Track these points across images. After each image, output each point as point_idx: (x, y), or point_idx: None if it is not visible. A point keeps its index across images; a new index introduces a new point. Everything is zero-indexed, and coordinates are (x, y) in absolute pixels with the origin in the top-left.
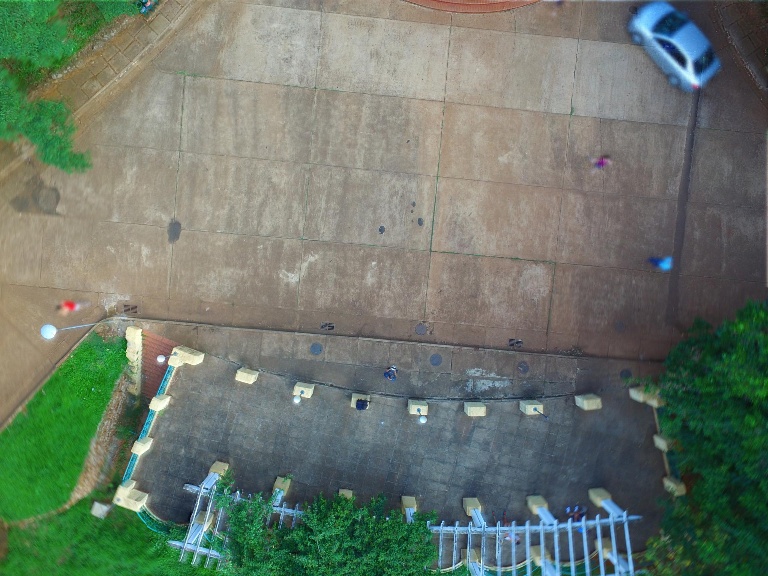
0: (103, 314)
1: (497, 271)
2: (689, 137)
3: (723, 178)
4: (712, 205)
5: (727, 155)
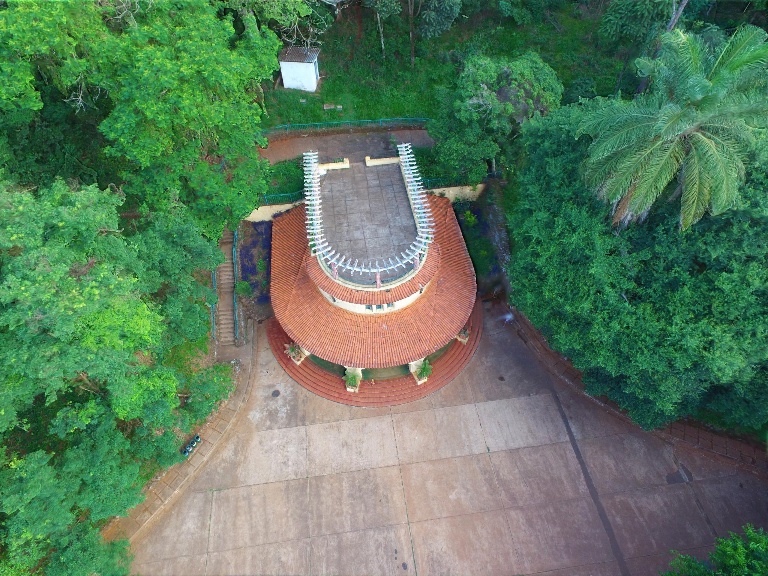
0: None
1: None
2: (575, 448)
3: (613, 471)
4: (617, 493)
5: (607, 454)
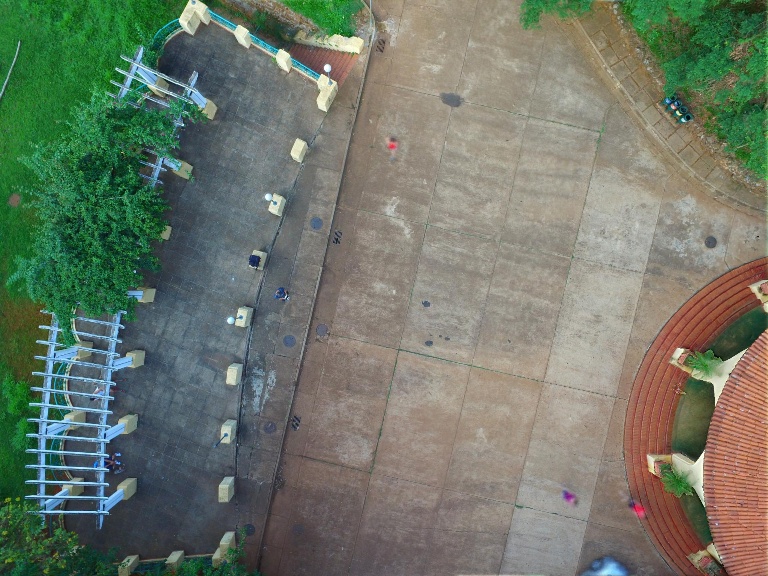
0: (379, 18)
1: (370, 413)
2: None
3: None
4: None
5: None
